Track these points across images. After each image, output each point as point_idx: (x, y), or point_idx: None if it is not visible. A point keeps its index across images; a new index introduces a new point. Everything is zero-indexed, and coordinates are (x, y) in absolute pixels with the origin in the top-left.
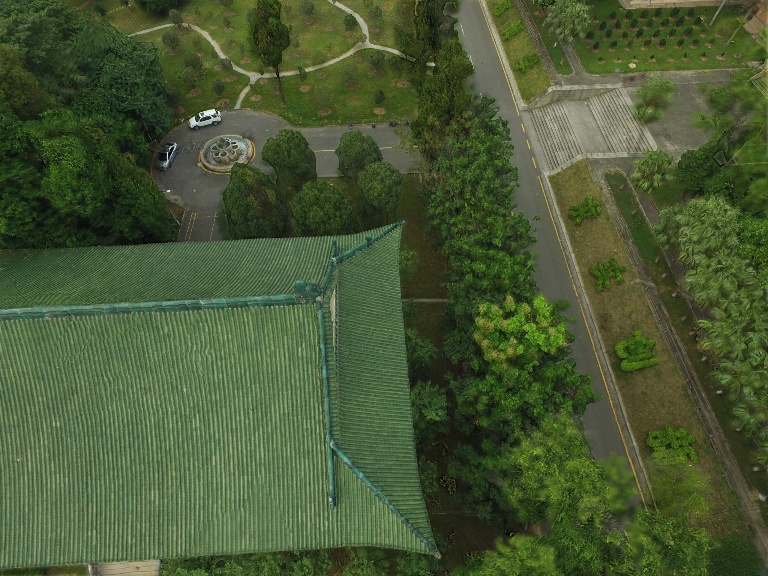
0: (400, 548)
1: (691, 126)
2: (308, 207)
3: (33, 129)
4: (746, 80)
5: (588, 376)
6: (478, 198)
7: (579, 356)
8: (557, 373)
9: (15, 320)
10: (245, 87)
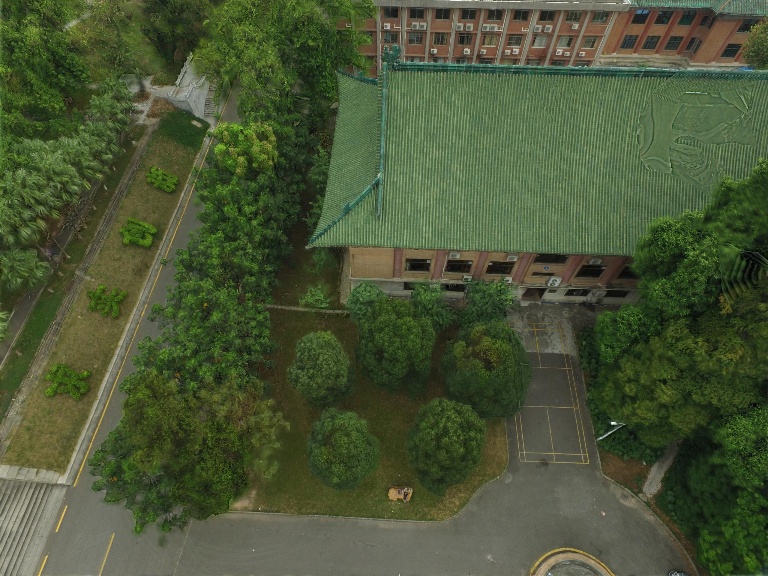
0: None
1: None
2: None
3: None
4: None
5: None
6: None
7: None
8: None
9: None
10: None
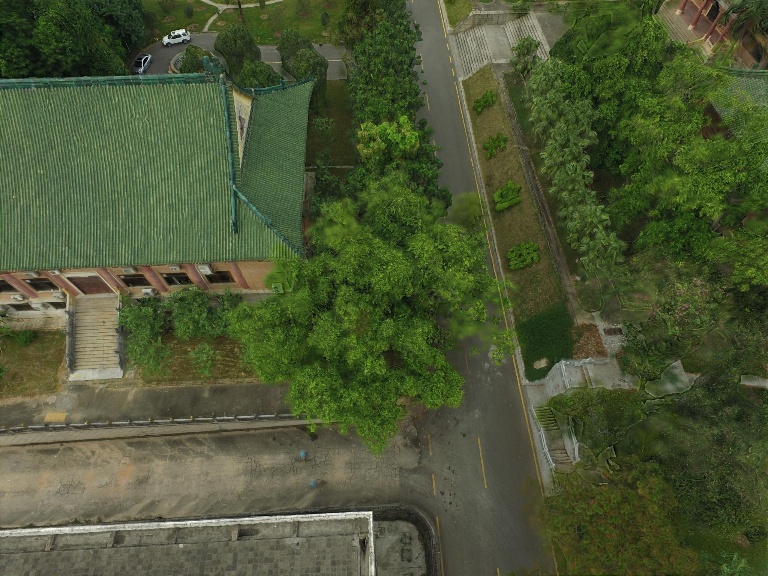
0: (281, 258)
1: None
2: (248, 80)
3: (27, 6)
4: (639, 8)
5: (437, 171)
6: (377, 64)
7: (467, 206)
8: (413, 167)
9: (11, 90)
10: (213, 15)
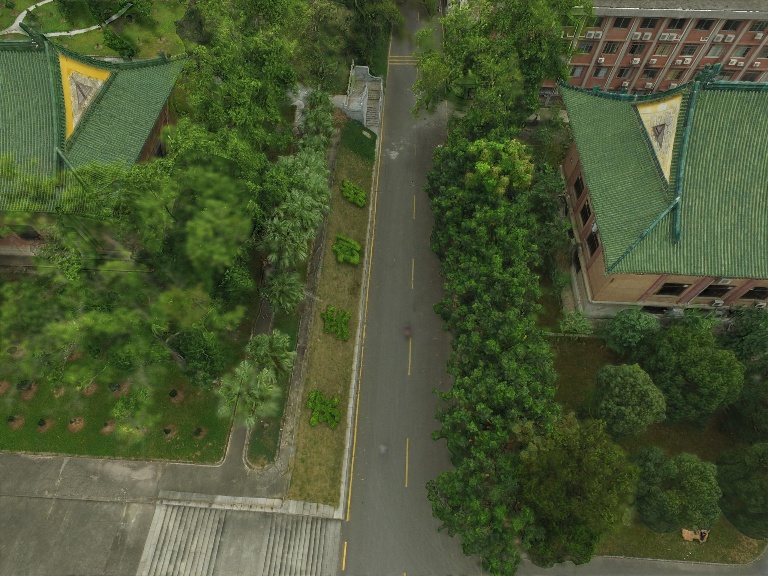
0: None
1: (58, 567)
2: None
3: None
4: None
5: None
6: None
7: (386, 272)
8: None
9: None
10: None
